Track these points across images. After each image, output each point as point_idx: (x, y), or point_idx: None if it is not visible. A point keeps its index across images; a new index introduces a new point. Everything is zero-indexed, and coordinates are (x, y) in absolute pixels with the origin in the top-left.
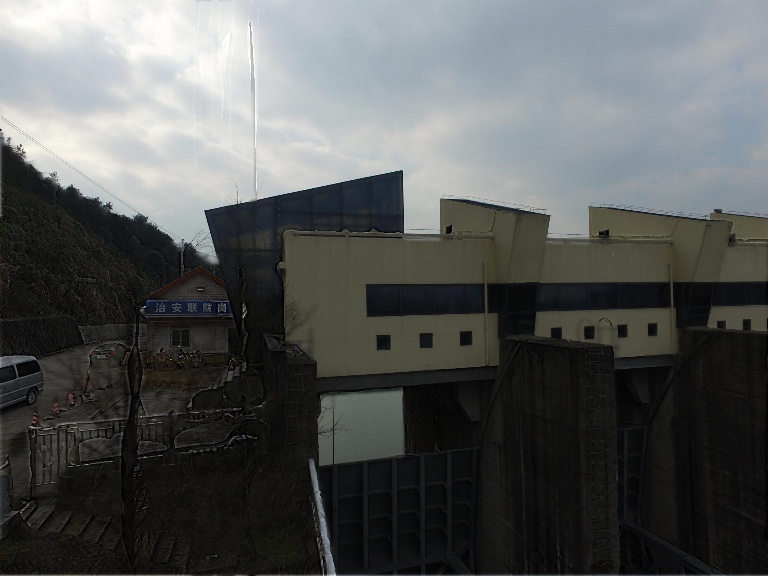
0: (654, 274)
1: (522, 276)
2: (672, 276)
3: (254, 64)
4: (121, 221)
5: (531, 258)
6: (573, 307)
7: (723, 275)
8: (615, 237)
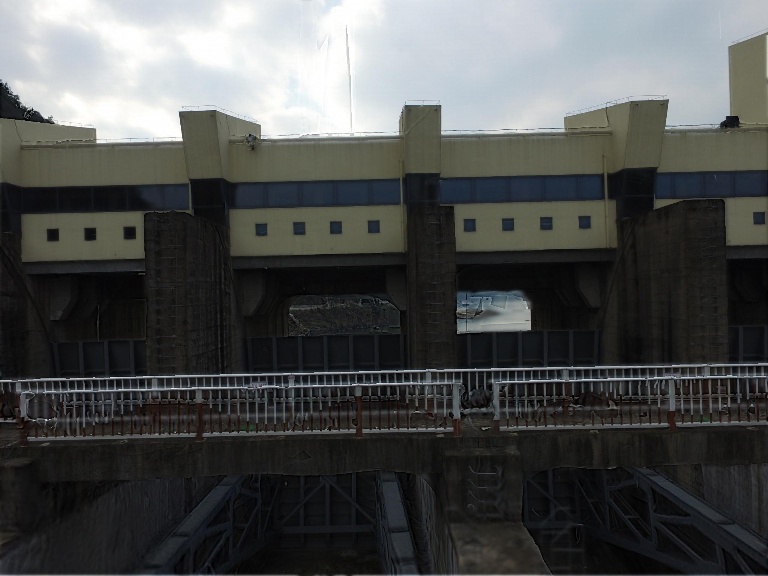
0: (173, 176)
1: None
2: None
3: (351, 64)
4: None
5: None
6: (75, 210)
7: (267, 175)
8: (126, 141)
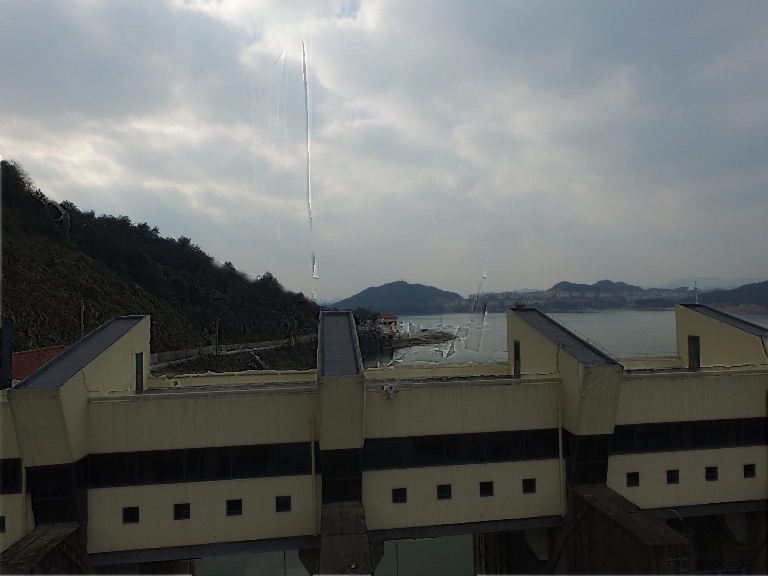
0: (289, 432)
1: (43, 458)
2: (314, 435)
3: (308, 81)
4: (138, 252)
5: (50, 437)
6: (160, 480)
7: (405, 428)
8: (230, 388)
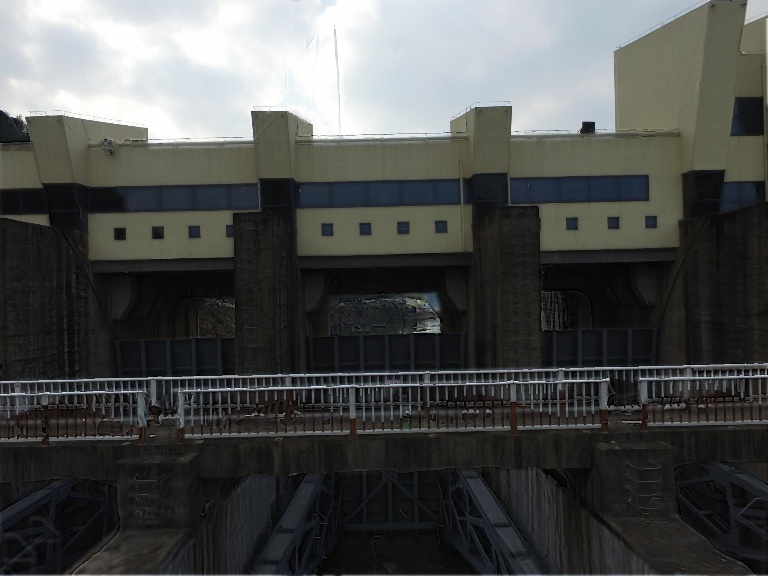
0: (32, 180)
1: None
2: None
3: (340, 63)
4: None
5: None
6: None
7: (126, 179)
8: None
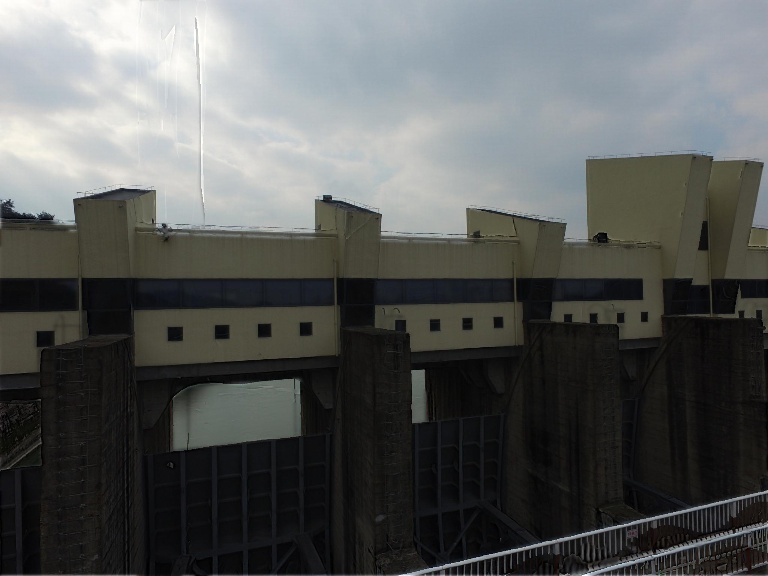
0: (54, 268)
1: None
2: None
3: (201, 61)
4: None
5: None
6: None
7: (183, 270)
8: None
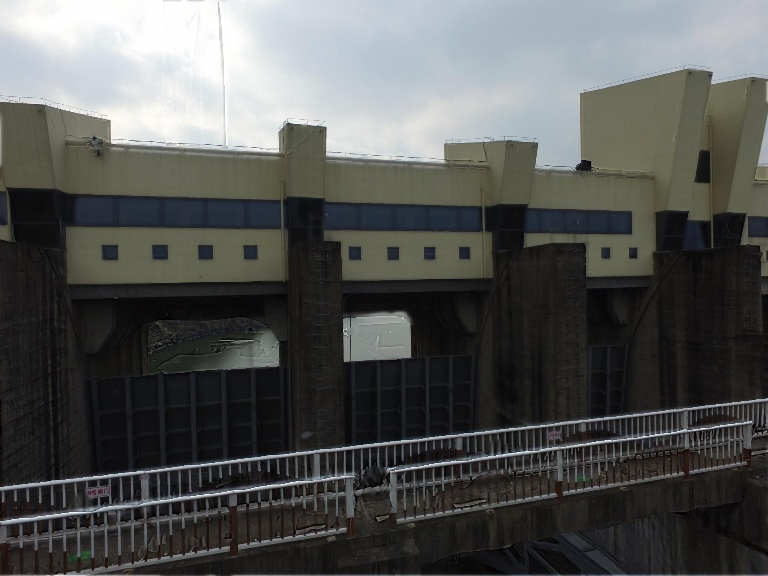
0: None
1: None
2: None
3: (224, 47)
4: None
5: None
6: None
7: (117, 187)
8: None
